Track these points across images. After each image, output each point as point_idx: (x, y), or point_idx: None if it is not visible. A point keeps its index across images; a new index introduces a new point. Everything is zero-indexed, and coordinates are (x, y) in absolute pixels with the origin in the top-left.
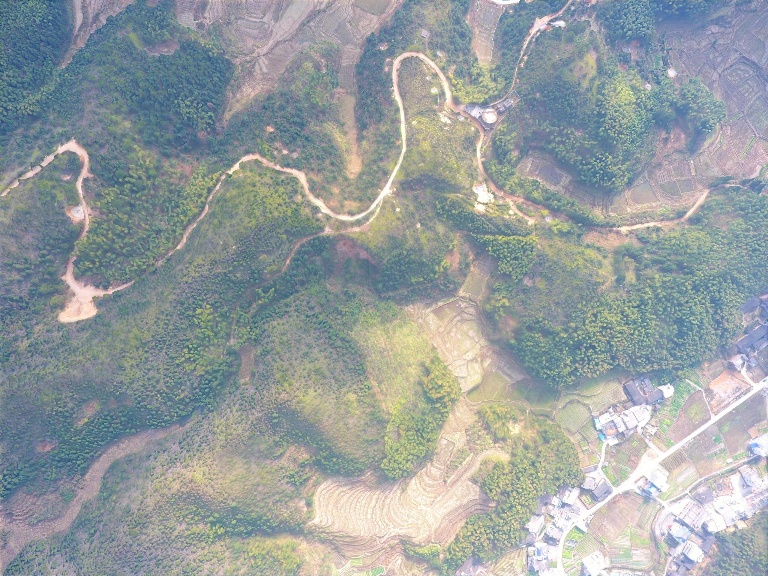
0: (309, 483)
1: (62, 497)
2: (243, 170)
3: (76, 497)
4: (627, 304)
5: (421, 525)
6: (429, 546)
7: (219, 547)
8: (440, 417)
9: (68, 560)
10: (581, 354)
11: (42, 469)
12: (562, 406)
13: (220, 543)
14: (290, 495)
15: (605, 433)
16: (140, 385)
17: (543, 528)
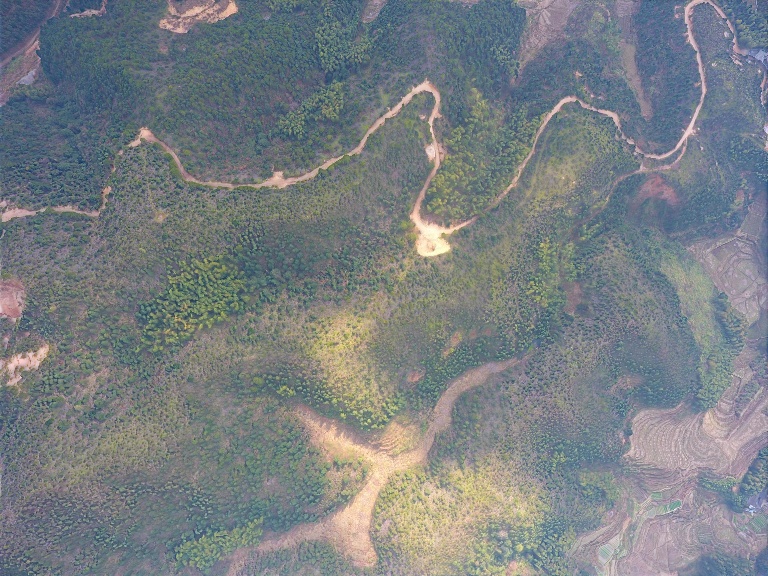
0: (628, 415)
1: (420, 428)
2: (569, 110)
3: (428, 429)
4: None
5: (720, 457)
6: (726, 478)
7: (557, 477)
8: (736, 351)
9: (439, 487)
10: None
11: (411, 399)
12: None
13: (557, 473)
14: (618, 425)
15: None
16: (504, 314)
17: None
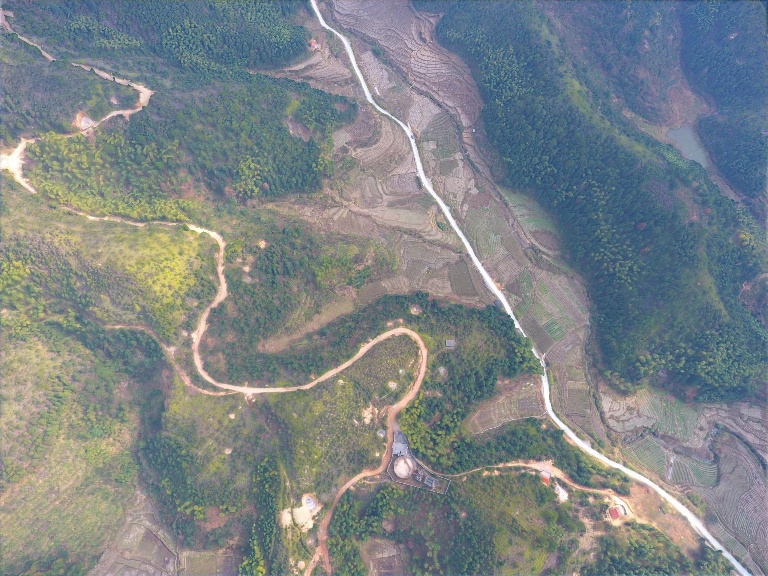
0: None
1: None
2: None
3: None
4: None
5: None
6: None
7: None
8: None
9: None
10: None
11: None
12: None
13: None
14: None
15: None
16: None
17: None
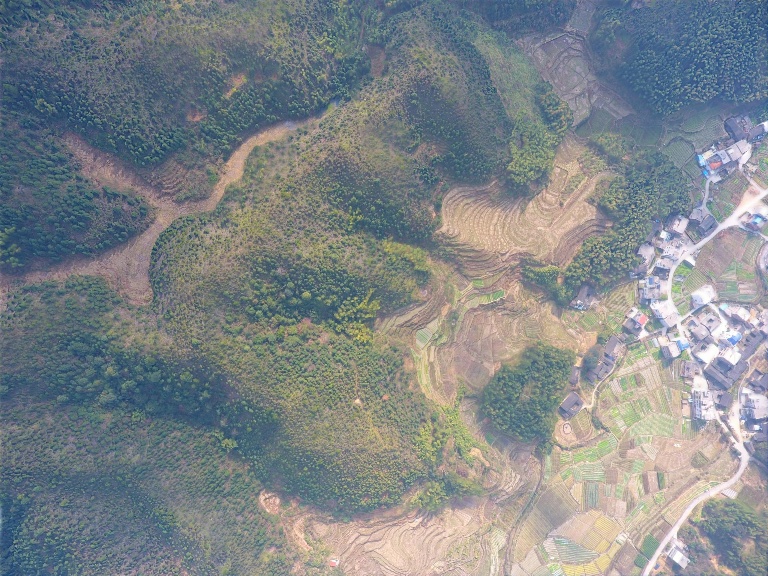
0: (438, 188)
1: (208, 176)
2: None
3: (219, 182)
4: (737, 13)
5: (541, 243)
6: (549, 266)
7: (357, 238)
8: (557, 137)
9: (220, 227)
10: (691, 72)
11: (192, 139)
12: (666, 143)
13: (357, 235)
14: (423, 192)
15: (709, 168)
16: (287, 54)
17: (653, 261)
